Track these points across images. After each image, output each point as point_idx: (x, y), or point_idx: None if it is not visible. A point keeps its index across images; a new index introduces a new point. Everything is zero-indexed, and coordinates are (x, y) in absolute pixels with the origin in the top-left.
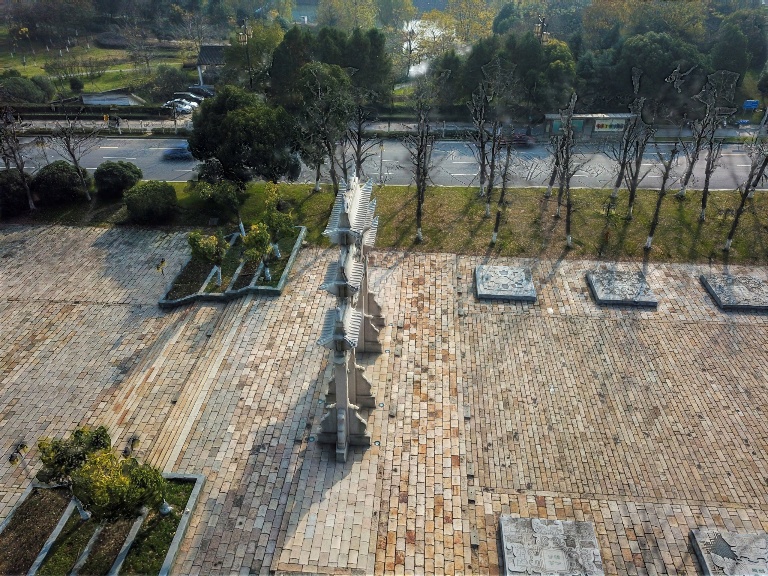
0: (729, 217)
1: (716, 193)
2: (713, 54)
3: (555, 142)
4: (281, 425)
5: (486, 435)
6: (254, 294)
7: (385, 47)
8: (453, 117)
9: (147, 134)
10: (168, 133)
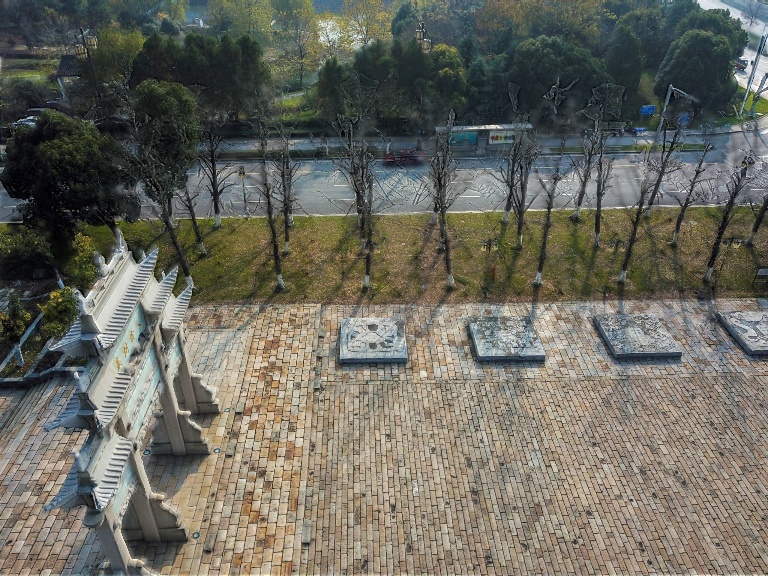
0: (621, 249)
1: (612, 212)
2: (607, 58)
3: (436, 164)
4: None
5: (327, 568)
6: (61, 377)
7: (261, 55)
8: None
9: None
10: None
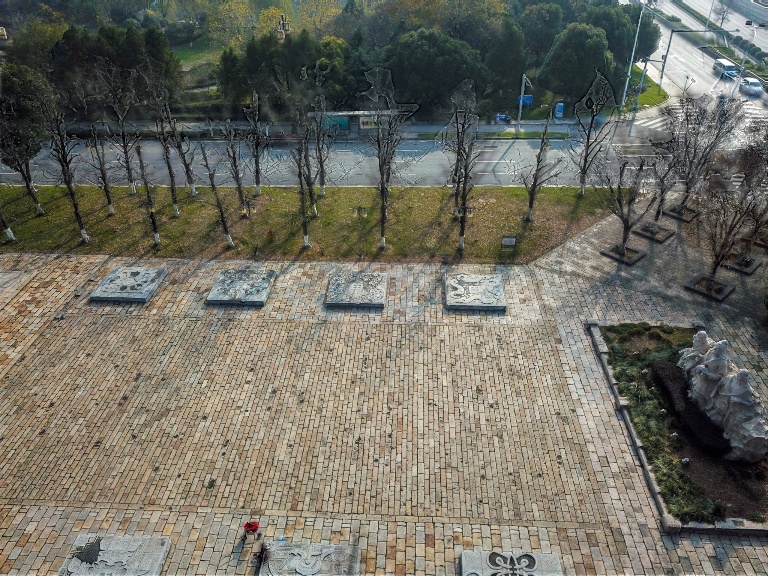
0: (363, 214)
1: (425, 190)
2: (490, 50)
3: (252, 141)
4: None
5: None
6: None
7: (168, 46)
8: (235, 116)
9: None
10: None
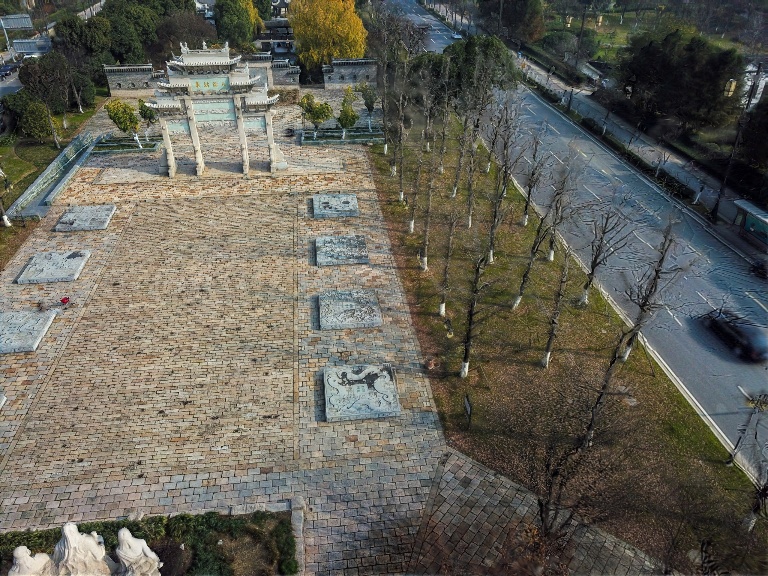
0: None
1: None
2: None
3: None
4: (188, 160)
5: None
6: None
7: (737, 75)
8: (720, 173)
9: (534, 86)
10: (542, 90)
